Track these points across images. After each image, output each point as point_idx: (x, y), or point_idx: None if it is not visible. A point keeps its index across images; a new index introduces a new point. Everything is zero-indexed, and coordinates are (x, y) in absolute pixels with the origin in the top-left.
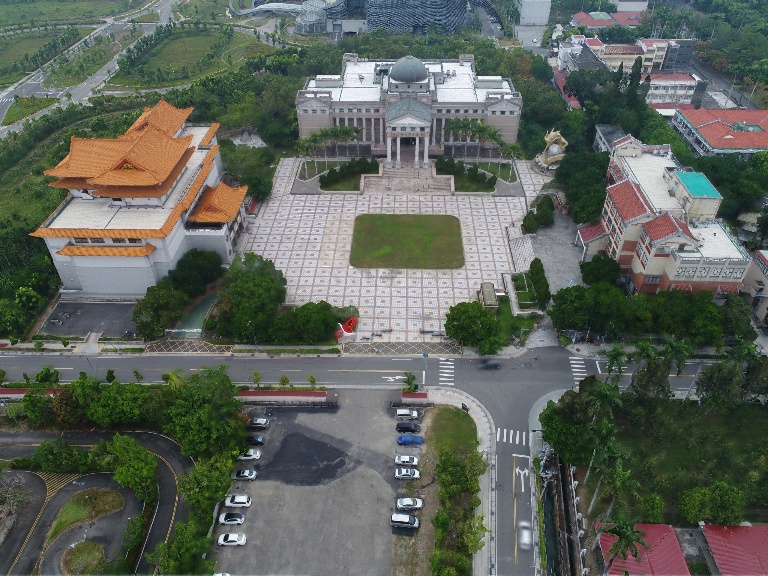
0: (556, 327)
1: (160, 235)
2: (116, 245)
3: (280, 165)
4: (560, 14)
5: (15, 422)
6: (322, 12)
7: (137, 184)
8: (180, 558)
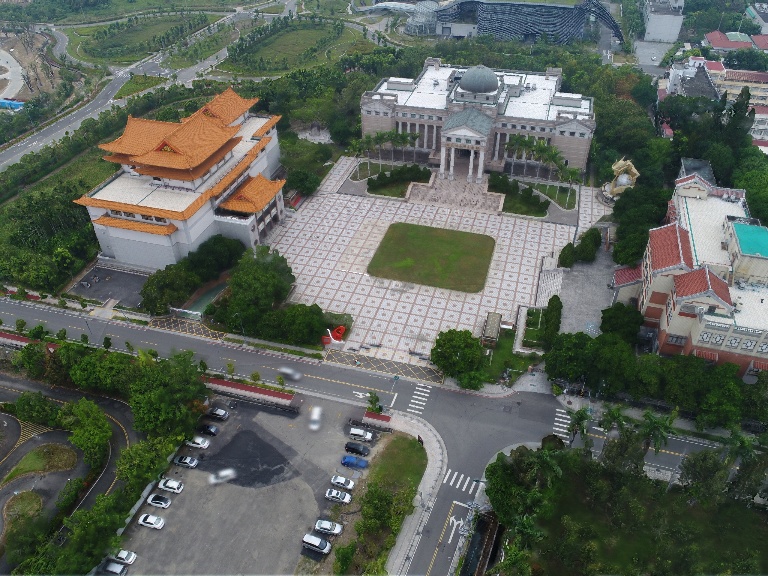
0: (548, 373)
1: (181, 217)
2: (145, 221)
3: (338, 163)
4: (694, 32)
5: (18, 369)
6: (433, 14)
7: (172, 166)
8: (86, 528)
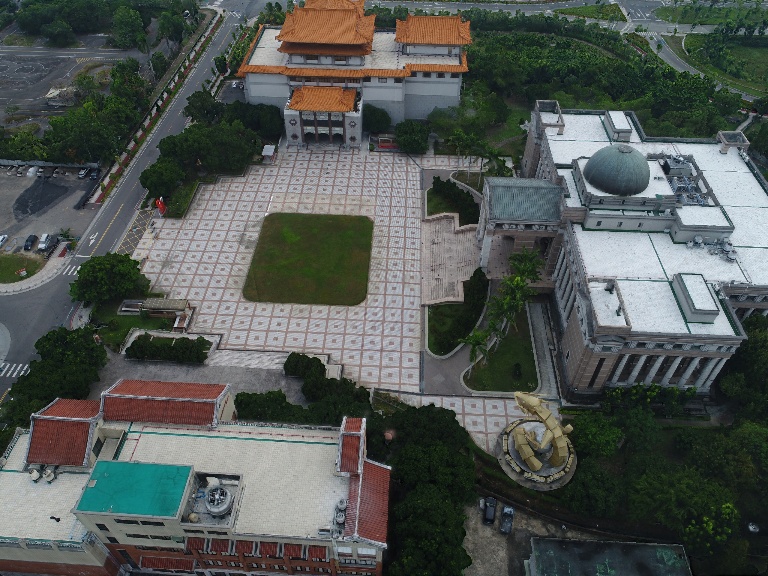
0: None
1: None
2: None
3: None
4: None
5: None
6: None
7: None
8: None
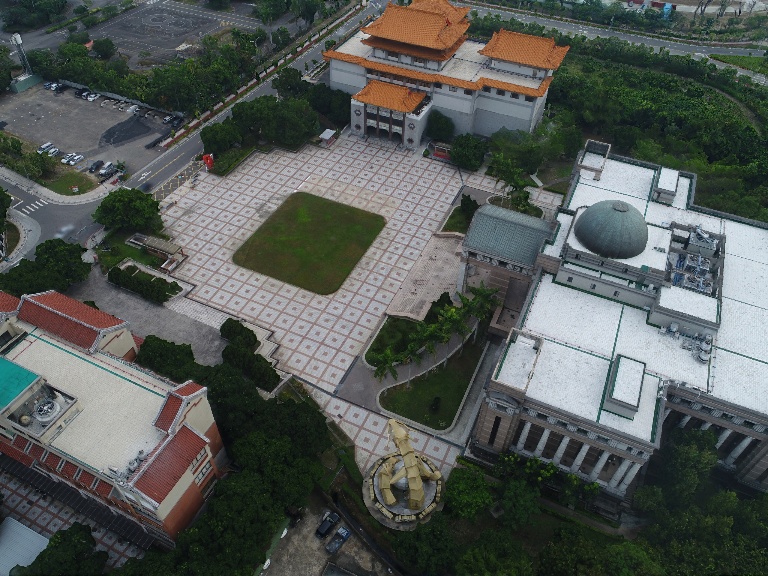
0: None
1: None
2: None
3: (542, 191)
4: None
5: None
6: None
7: None
8: None
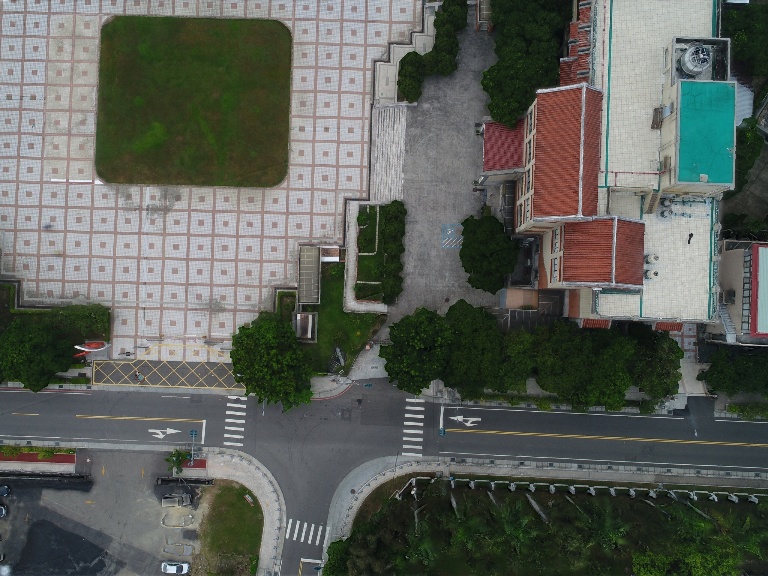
0: None
1: None
2: None
3: None
4: None
5: None
6: None
7: None
8: None
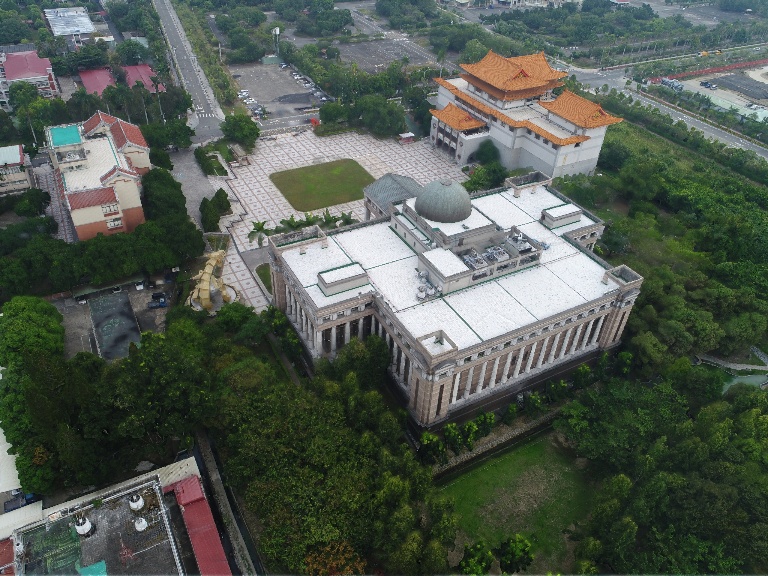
0: None
1: None
2: None
3: None
4: None
5: None
6: None
7: None
8: None
